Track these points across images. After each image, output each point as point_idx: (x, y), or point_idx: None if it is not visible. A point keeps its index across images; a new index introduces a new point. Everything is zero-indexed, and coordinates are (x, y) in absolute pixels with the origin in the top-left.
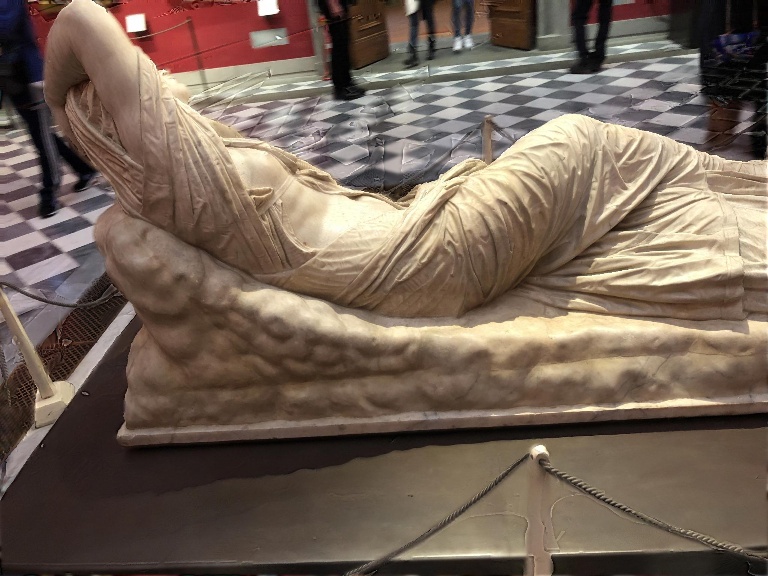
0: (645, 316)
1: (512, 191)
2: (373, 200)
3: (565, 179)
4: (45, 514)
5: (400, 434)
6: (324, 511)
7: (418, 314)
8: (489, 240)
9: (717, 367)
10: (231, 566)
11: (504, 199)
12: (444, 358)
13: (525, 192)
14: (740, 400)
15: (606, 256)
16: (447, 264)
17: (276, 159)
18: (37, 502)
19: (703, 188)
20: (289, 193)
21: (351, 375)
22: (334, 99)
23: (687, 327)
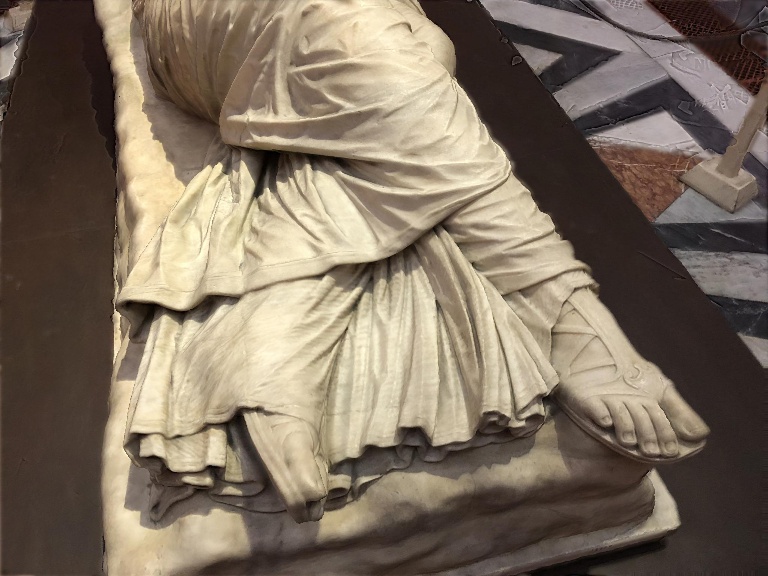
0: None
1: None
2: None
3: (212, 18)
4: (76, 16)
5: None
6: (50, 137)
7: None
8: None
9: None
10: (7, 107)
11: None
12: None
13: None
14: None
15: (228, 173)
16: None
17: None
18: (87, 9)
19: (381, 241)
20: None
21: None
22: None
23: None
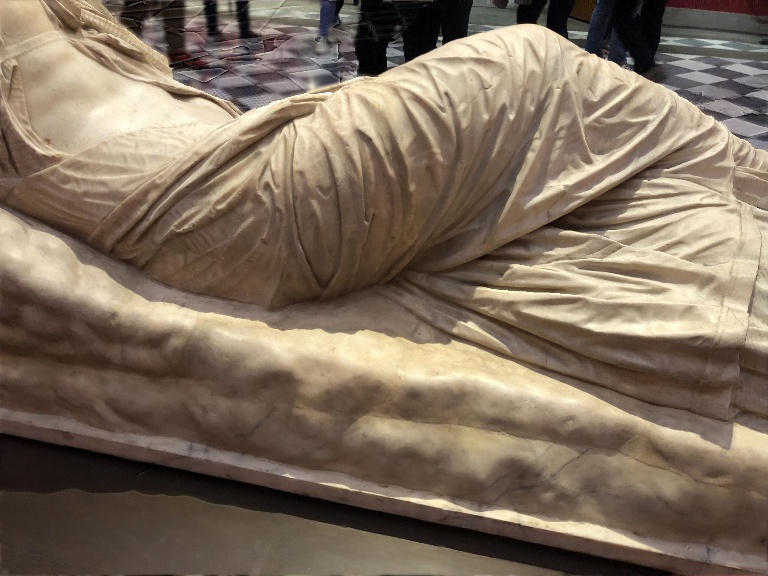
0: (566, 375)
1: (385, 121)
2: (210, 106)
3: (483, 121)
4: None
5: (152, 466)
6: None
7: (209, 291)
8: (331, 195)
9: (660, 490)
10: None
11: (368, 132)
12: (221, 369)
13: (408, 128)
14: (688, 552)
15: (532, 264)
16: (258, 220)
17: None
18: None
19: (723, 191)
20: (38, 55)
21: (85, 362)
22: (305, 4)
23: (627, 410)
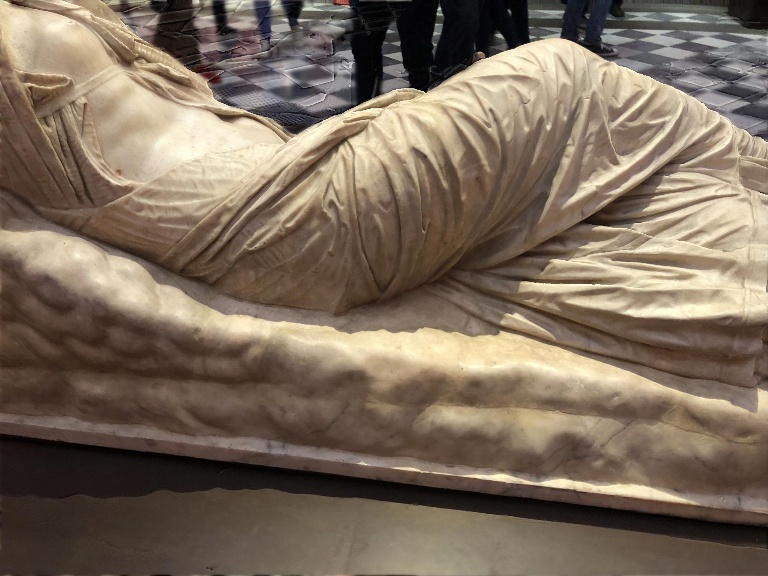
0: (608, 356)
1: (438, 139)
2: (255, 125)
3: (524, 133)
4: None
5: (232, 464)
6: (83, 569)
7: (278, 301)
8: (392, 209)
9: (698, 452)
10: None
11: (423, 149)
12: (299, 373)
13: (458, 144)
14: (723, 503)
15: (569, 258)
16: (324, 235)
17: (94, 36)
18: None
19: (731, 180)
20: (104, 91)
21: (166, 374)
22: (297, 2)
23: (665, 384)
